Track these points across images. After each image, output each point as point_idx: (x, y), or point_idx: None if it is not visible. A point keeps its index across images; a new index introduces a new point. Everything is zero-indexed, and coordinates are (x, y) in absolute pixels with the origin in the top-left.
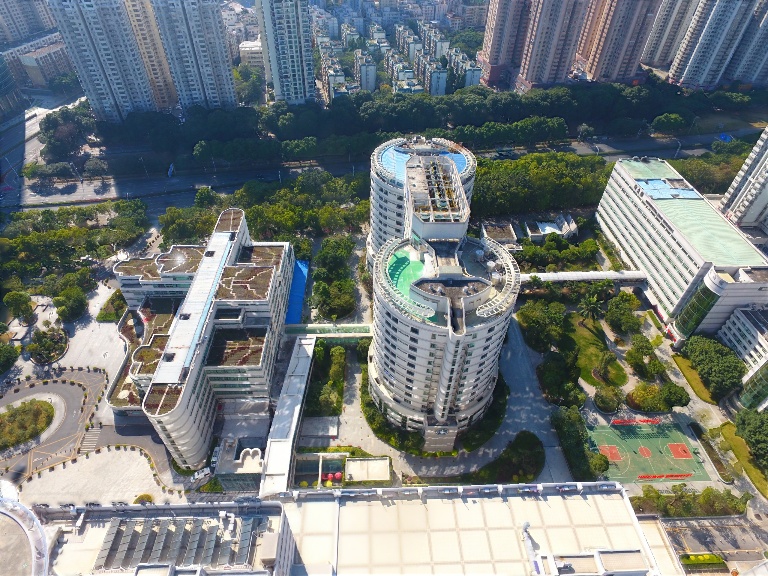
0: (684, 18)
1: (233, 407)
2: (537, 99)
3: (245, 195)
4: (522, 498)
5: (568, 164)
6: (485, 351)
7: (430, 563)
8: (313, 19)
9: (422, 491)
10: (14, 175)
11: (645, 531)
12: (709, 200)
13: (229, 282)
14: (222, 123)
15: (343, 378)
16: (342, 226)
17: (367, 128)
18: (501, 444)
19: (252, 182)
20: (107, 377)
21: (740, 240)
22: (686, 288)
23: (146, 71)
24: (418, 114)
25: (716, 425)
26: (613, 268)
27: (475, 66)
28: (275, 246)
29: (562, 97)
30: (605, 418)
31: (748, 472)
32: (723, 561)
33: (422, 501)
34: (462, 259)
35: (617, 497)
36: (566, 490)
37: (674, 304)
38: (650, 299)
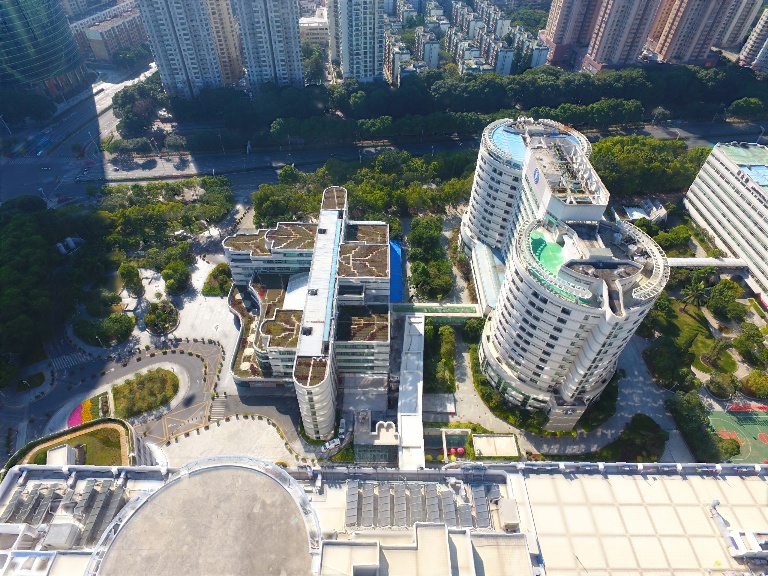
0: None
1: (353, 381)
2: (610, 80)
3: (327, 174)
4: (701, 477)
5: None
6: (628, 334)
7: (626, 535)
8: None
9: (603, 467)
10: (93, 149)
11: None
12: None
13: (348, 259)
14: (295, 100)
15: None
16: (429, 207)
17: (438, 108)
18: (618, 426)
19: (333, 161)
20: (223, 349)
21: None
22: None
23: None
24: (490, 94)
25: None
26: (712, 255)
27: (542, 45)
28: (378, 225)
29: (636, 79)
30: (720, 404)
31: None
32: None
33: (603, 476)
34: None
35: None
36: (744, 471)
37: None
38: (752, 287)
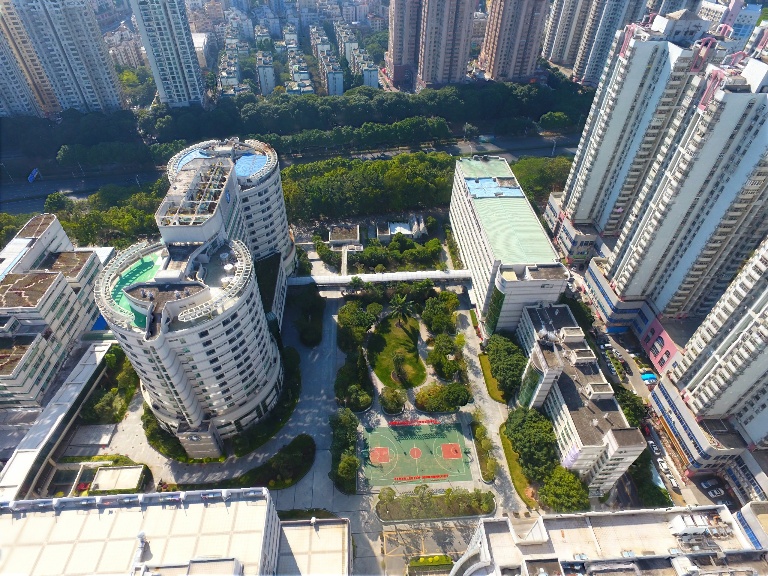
0: (587, 17)
1: (3, 417)
2: (424, 99)
3: (99, 200)
4: (162, 507)
5: (437, 164)
6: (211, 356)
7: None
8: (229, 21)
9: (57, 502)
10: None
11: (328, 536)
12: (556, 198)
13: (4, 289)
14: (94, 127)
15: (135, 385)
16: None
17: (248, 130)
18: (274, 448)
19: (108, 186)
20: None
21: (541, 238)
22: (487, 287)
23: (31, 75)
24: (300, 115)
25: (497, 424)
26: (440, 267)
27: (372, 66)
28: (84, 251)
29: (449, 97)
30: (388, 419)
31: (512, 471)
32: (452, 562)
33: (55, 513)
34: (209, 262)
35: (262, 503)
36: (210, 497)
37: (483, 303)
38: (471, 298)
